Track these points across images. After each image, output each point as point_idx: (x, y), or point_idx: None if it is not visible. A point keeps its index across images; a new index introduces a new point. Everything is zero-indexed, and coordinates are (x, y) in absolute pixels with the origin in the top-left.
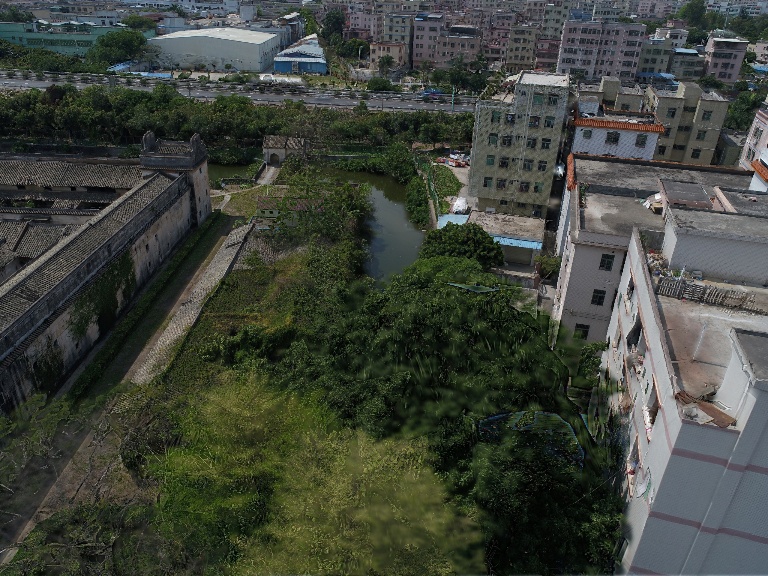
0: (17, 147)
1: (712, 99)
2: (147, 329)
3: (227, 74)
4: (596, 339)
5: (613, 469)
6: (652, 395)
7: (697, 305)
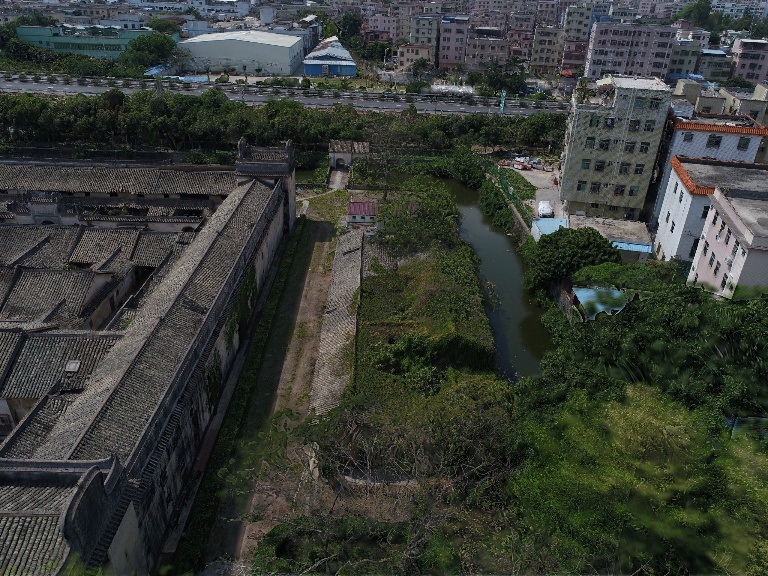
0: (79, 153)
1: None
2: (281, 337)
3: (258, 77)
4: None
5: None
6: None
7: None
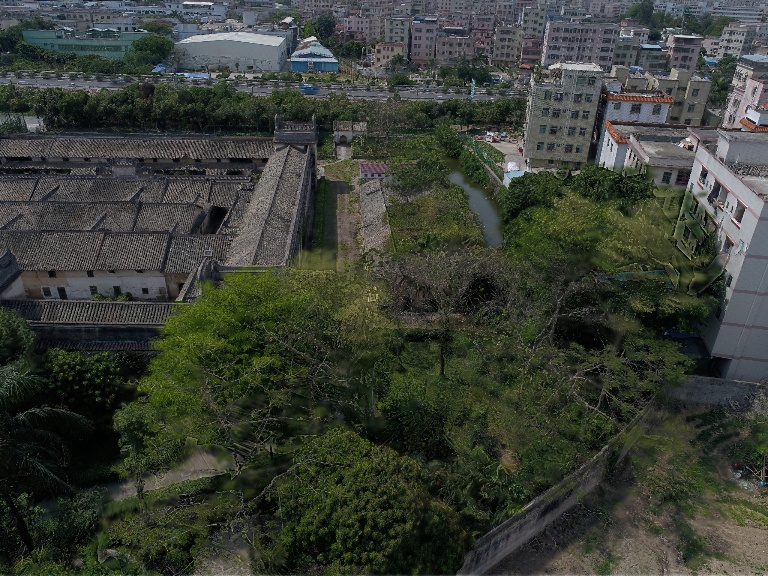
0: None
1: (698, 80)
2: (330, 250)
3: (250, 74)
4: None
5: (707, 266)
6: (736, 210)
7: (746, 176)
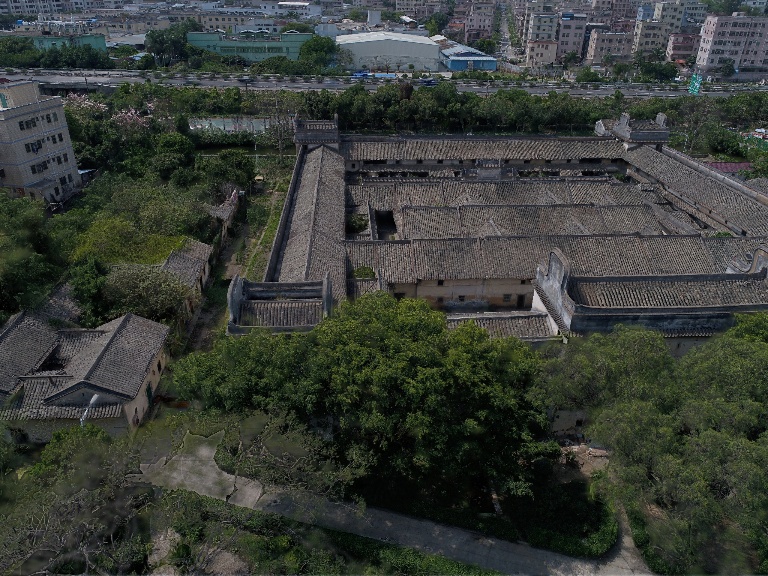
0: None
1: None
2: None
3: None
4: None
5: None
6: None
7: None
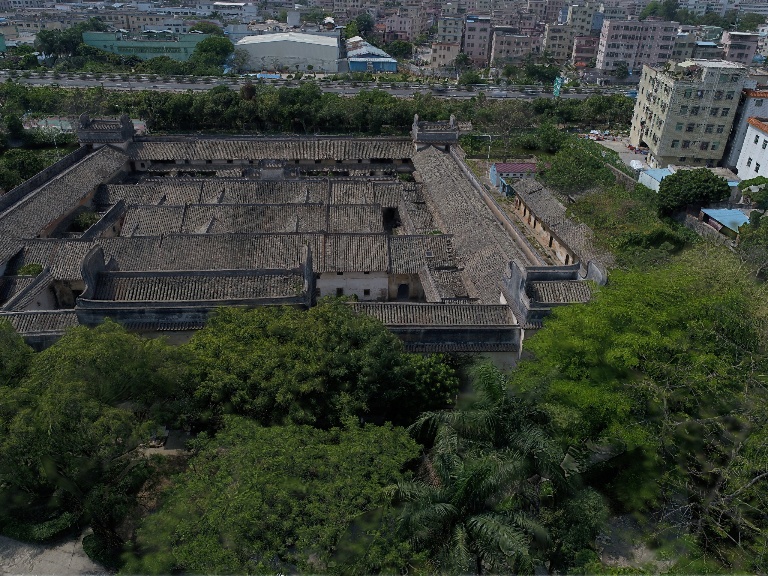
0: None
1: None
2: None
3: (311, 74)
4: None
5: None
6: None
7: None
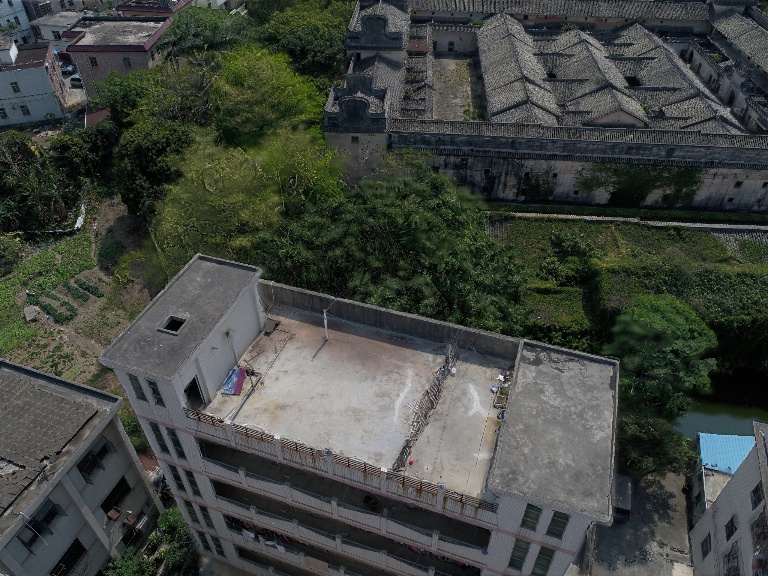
0: None
1: None
2: None
3: None
4: (704, 573)
5: None
6: None
7: None
